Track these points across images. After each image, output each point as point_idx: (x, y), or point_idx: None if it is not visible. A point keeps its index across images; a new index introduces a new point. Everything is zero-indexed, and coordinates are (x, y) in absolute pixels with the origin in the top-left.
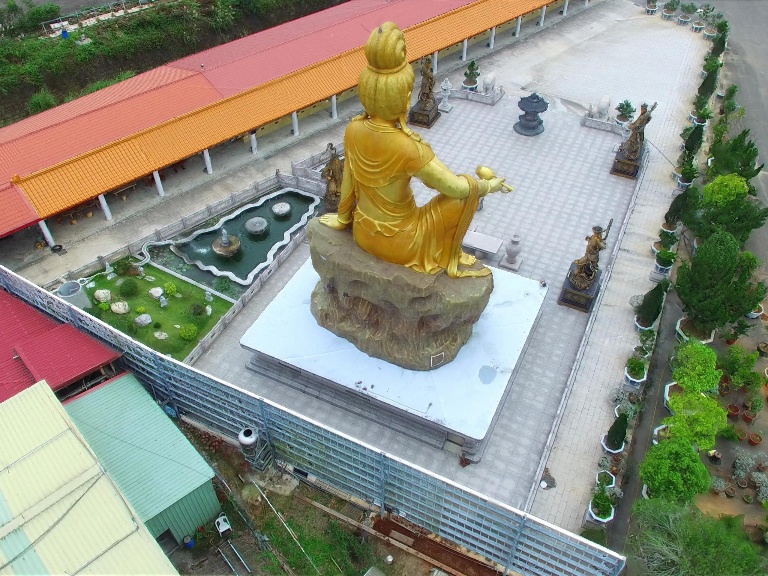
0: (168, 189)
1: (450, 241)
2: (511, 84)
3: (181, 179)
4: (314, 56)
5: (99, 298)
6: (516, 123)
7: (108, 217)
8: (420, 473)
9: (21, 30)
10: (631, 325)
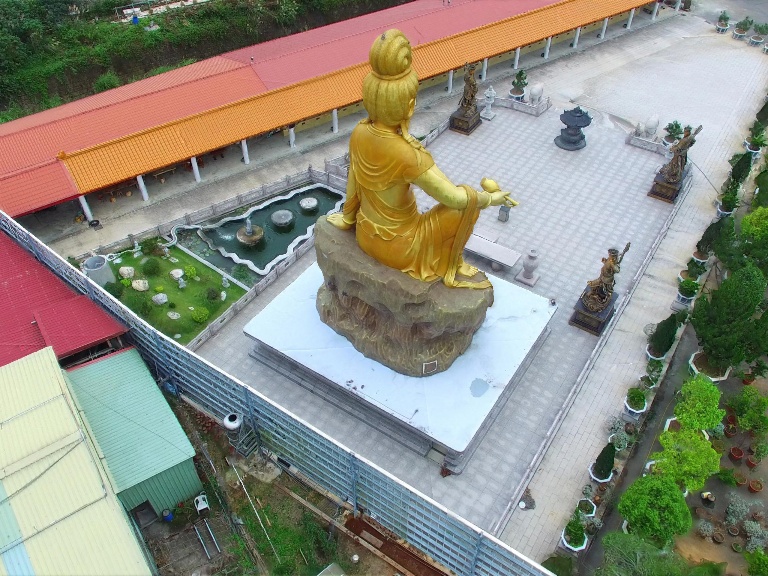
0: (205, 175)
1: (448, 250)
2: (560, 96)
3: (219, 167)
4: (362, 55)
5: (123, 274)
6: (558, 136)
7: (145, 198)
8: (386, 477)
9: (96, 14)
10: (642, 353)
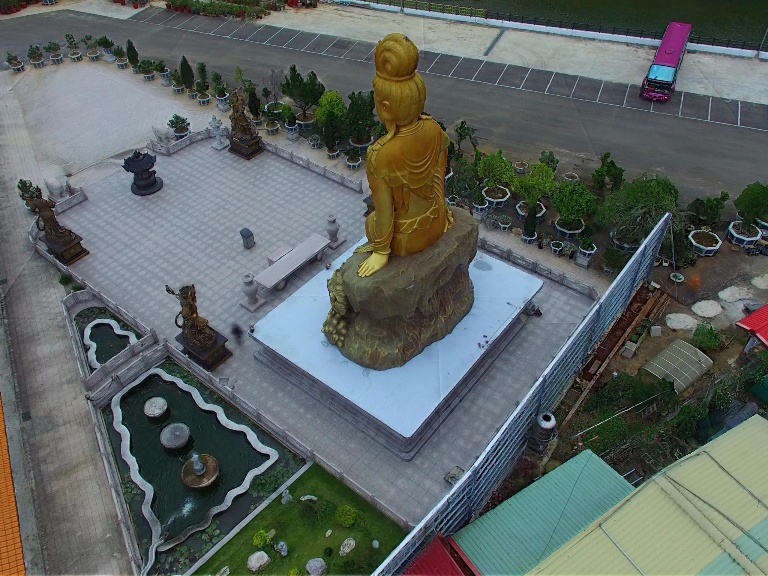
0: None
1: None
2: None
3: None
4: None
5: None
6: (134, 191)
7: None
8: None
9: None
10: None
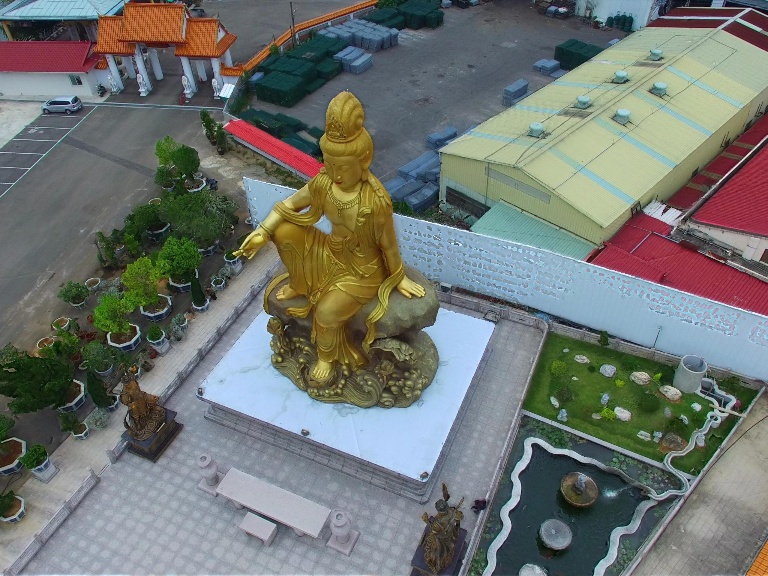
0: None
1: None
2: None
3: None
4: None
5: None
6: None
7: None
8: None
9: None
10: (121, 409)
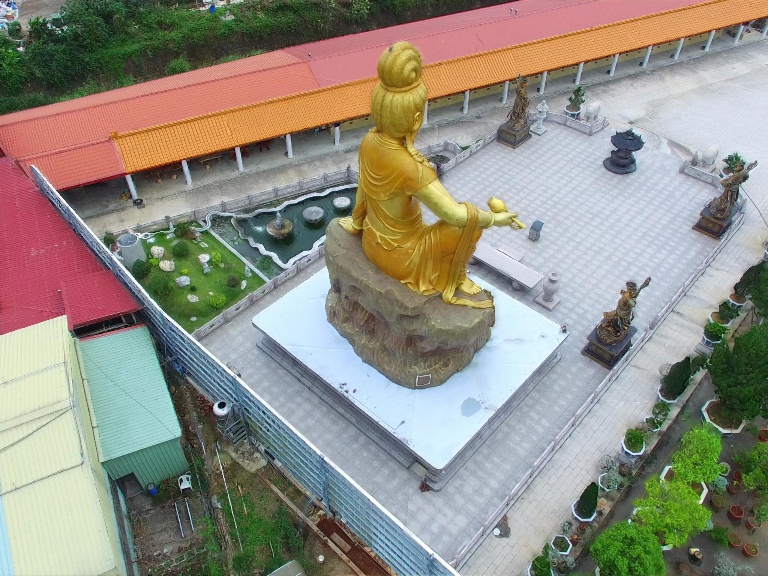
0: (248, 165)
1: (448, 266)
2: (619, 116)
3: (263, 158)
4: None
5: (153, 253)
6: (608, 158)
7: (188, 182)
8: None
9: (177, 0)
10: (654, 393)
